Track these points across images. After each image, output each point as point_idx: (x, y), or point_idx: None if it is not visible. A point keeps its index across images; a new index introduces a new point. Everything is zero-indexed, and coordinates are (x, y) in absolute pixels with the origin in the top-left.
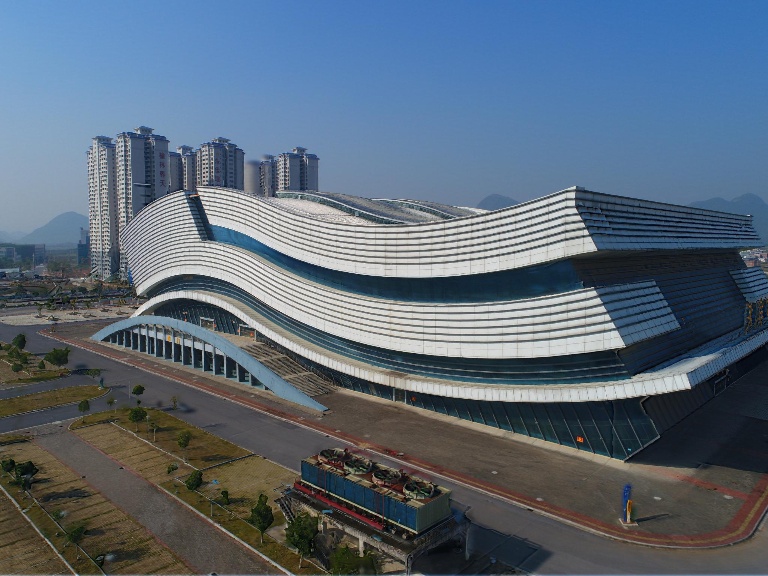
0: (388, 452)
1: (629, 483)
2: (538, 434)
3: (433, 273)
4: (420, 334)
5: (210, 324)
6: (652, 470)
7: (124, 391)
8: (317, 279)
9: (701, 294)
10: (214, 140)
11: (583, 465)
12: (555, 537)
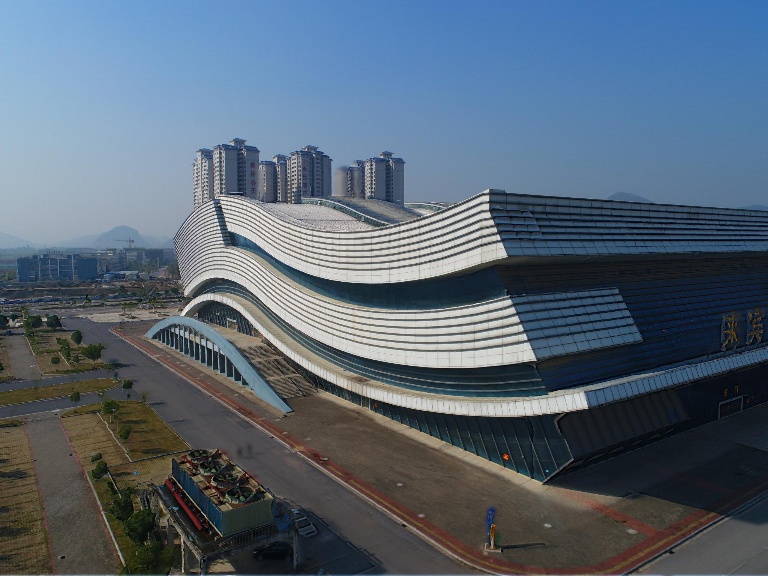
0: (314, 456)
1: (530, 507)
2: (472, 448)
3: (381, 279)
4: (375, 340)
5: (234, 325)
6: (568, 495)
7: (132, 385)
8: (305, 284)
9: (709, 303)
10: (303, 148)
11: (496, 484)
12: (404, 555)
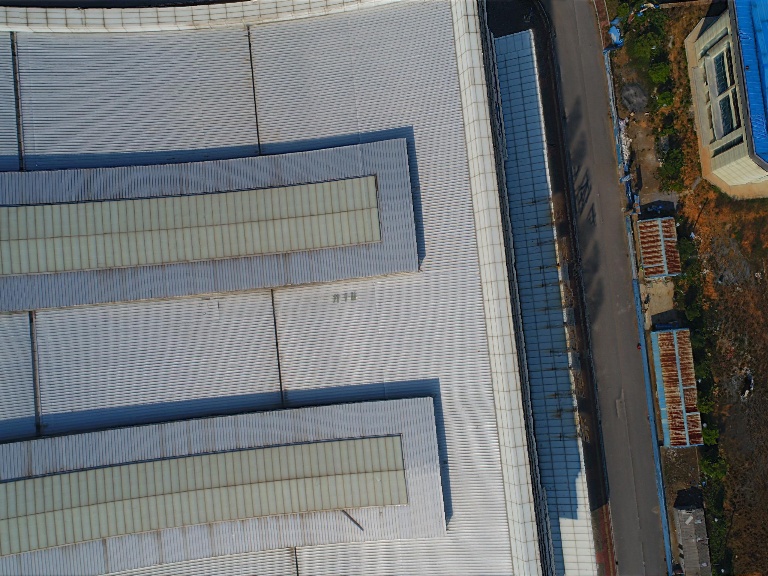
0: None
1: None
2: None
3: None
4: None
5: None
6: None
7: None
8: None
9: None
10: None
11: None
12: None
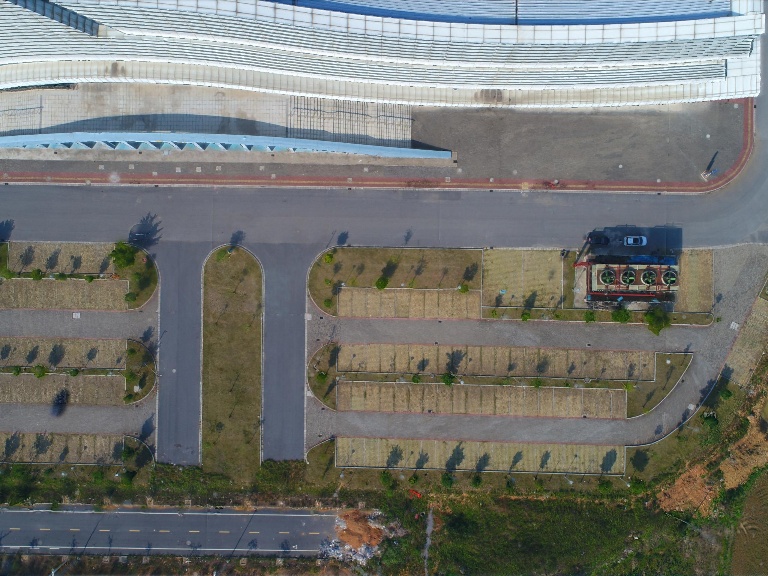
0: (548, 186)
1: (690, 128)
2: None
3: None
4: None
5: None
6: None
7: (258, 241)
8: None
9: None
10: None
11: (659, 122)
12: (683, 212)
